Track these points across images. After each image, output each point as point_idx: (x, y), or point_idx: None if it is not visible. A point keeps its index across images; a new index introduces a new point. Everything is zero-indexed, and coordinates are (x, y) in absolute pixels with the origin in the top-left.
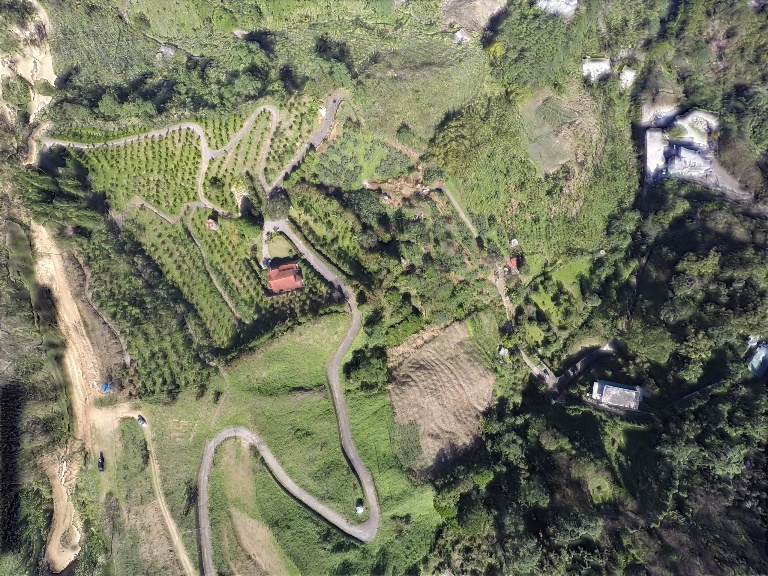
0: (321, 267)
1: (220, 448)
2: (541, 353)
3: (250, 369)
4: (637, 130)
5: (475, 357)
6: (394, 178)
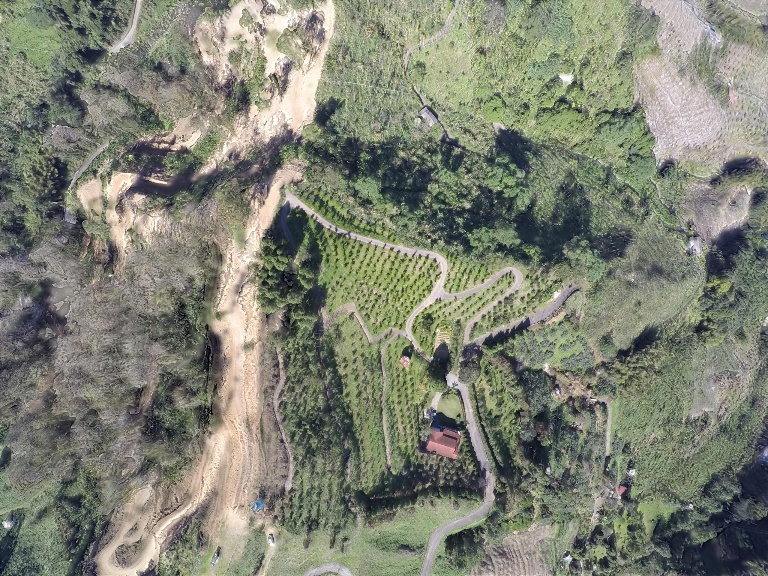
0: (478, 444)
1: None
2: (594, 569)
3: (381, 525)
4: None
5: (547, 558)
6: (572, 372)
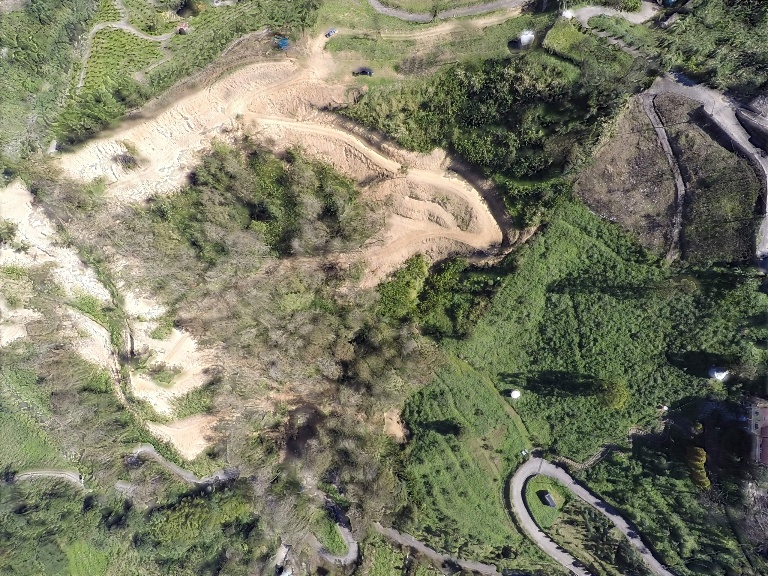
0: None
1: (384, 1)
2: None
3: None
4: None
5: None
6: None
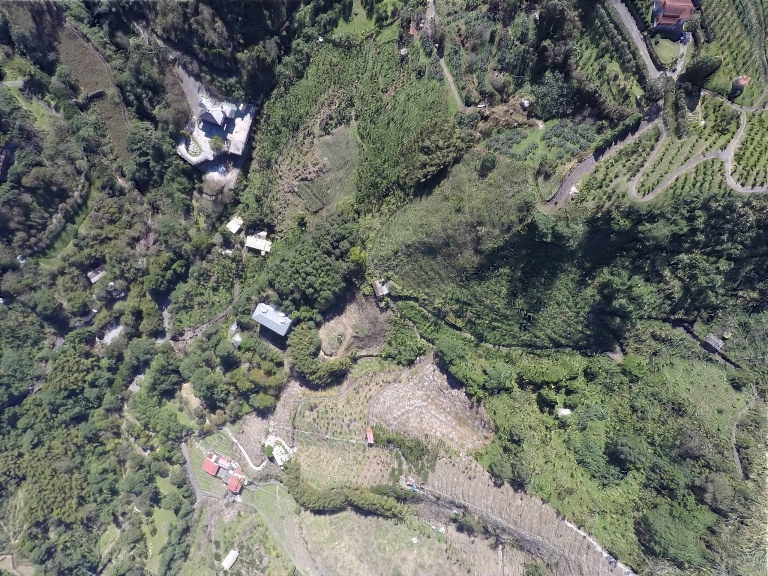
0: (628, 21)
1: None
2: None
3: None
4: (248, 161)
5: None
6: (509, 128)
